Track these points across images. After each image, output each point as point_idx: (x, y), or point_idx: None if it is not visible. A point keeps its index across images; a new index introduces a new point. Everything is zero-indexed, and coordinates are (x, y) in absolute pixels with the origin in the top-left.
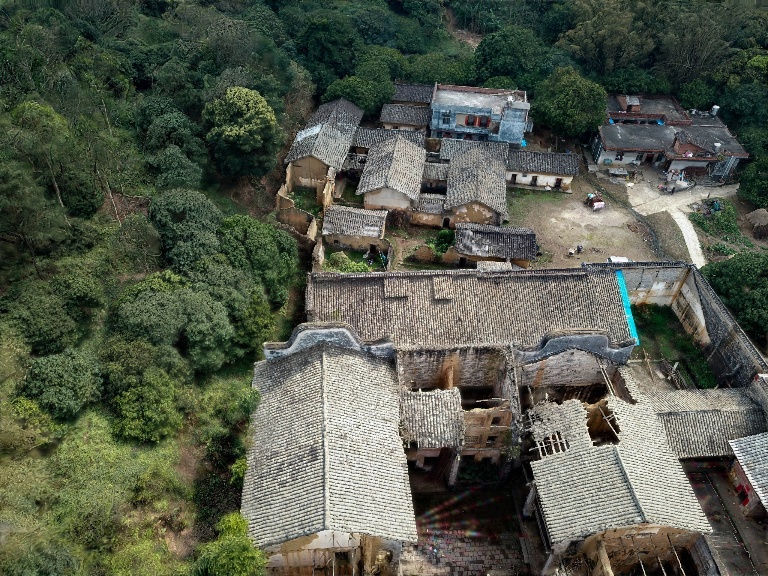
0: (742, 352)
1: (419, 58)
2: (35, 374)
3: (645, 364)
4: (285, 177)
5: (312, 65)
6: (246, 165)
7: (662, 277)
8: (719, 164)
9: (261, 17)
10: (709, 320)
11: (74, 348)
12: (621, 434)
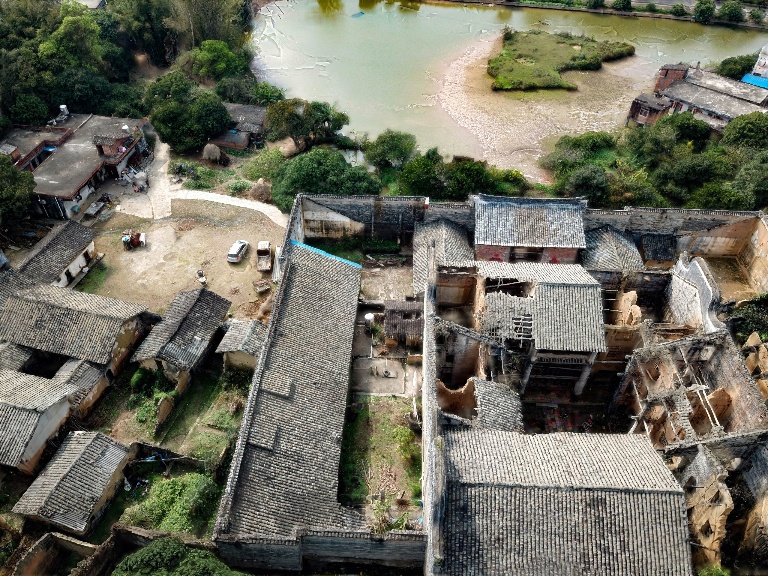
0: (395, 207)
1: None
2: None
3: (363, 275)
4: None
5: None
6: None
7: (298, 220)
8: None
9: None
10: (350, 214)
11: None
12: (520, 279)
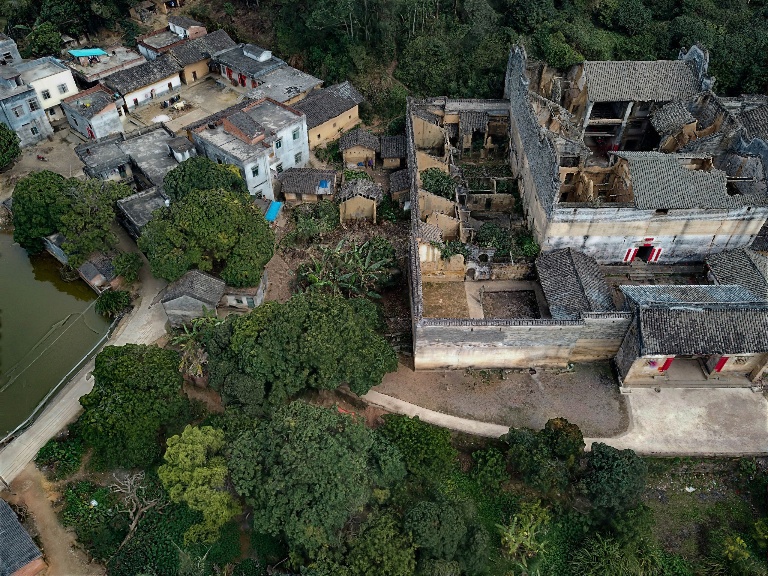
0: None
1: None
2: (630, 0)
3: None
4: None
5: None
6: None
7: None
8: None
9: None
10: None
11: (656, 19)
12: None
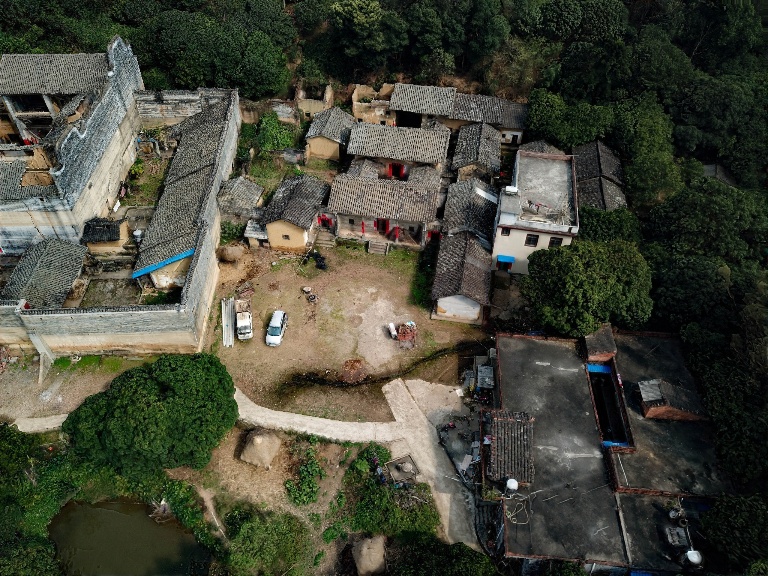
0: None
1: (660, 152)
2: None
3: None
4: (382, 87)
5: (571, 73)
6: None
7: None
8: None
9: (593, 8)
10: None
11: None
12: None
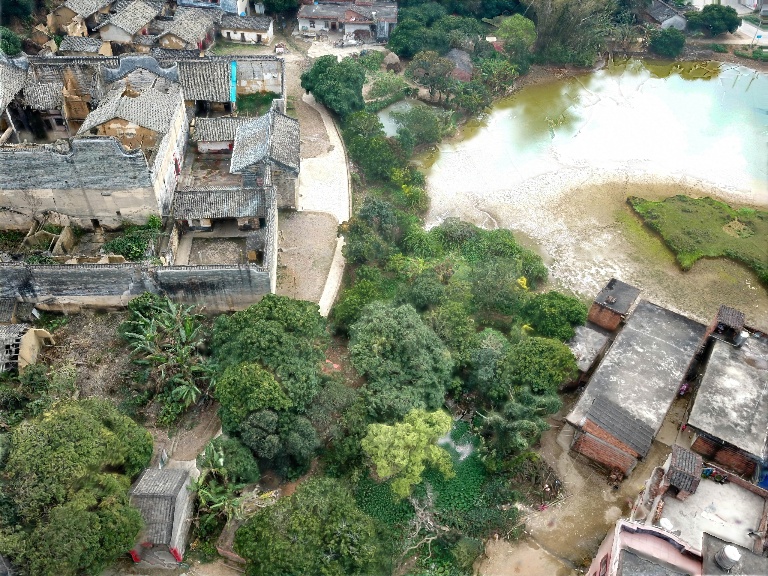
0: None
1: None
2: None
3: None
4: (46, 20)
5: None
6: (4, 1)
7: (266, 68)
8: (379, 28)
9: None
10: None
11: None
12: (138, 96)
